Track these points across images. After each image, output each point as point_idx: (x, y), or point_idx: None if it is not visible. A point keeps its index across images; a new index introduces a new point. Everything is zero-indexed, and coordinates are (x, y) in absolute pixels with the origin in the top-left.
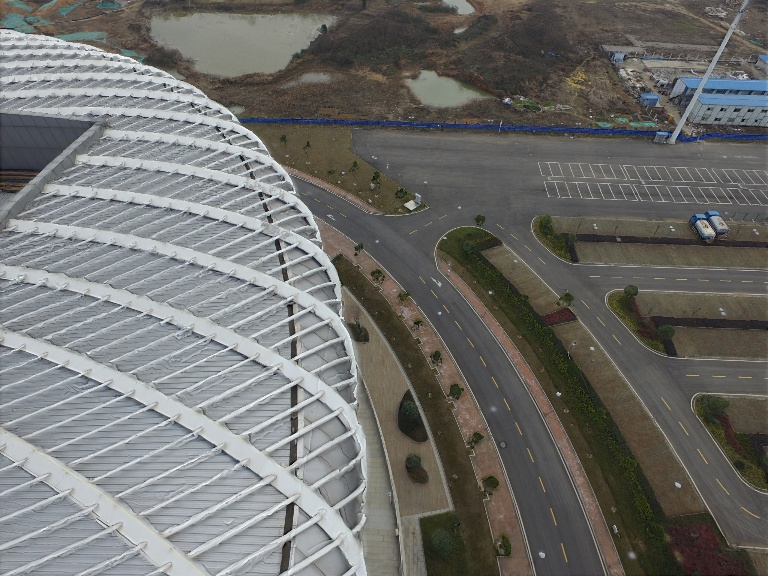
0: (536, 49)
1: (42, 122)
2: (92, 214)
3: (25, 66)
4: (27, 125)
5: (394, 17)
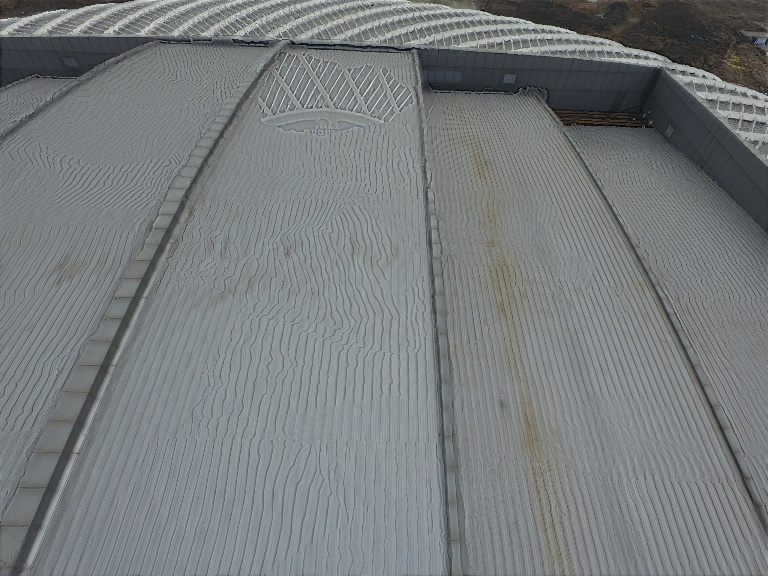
0: (686, 33)
1: (615, 68)
2: (766, 129)
3: (508, 28)
4: (600, 70)
5: (538, 3)
